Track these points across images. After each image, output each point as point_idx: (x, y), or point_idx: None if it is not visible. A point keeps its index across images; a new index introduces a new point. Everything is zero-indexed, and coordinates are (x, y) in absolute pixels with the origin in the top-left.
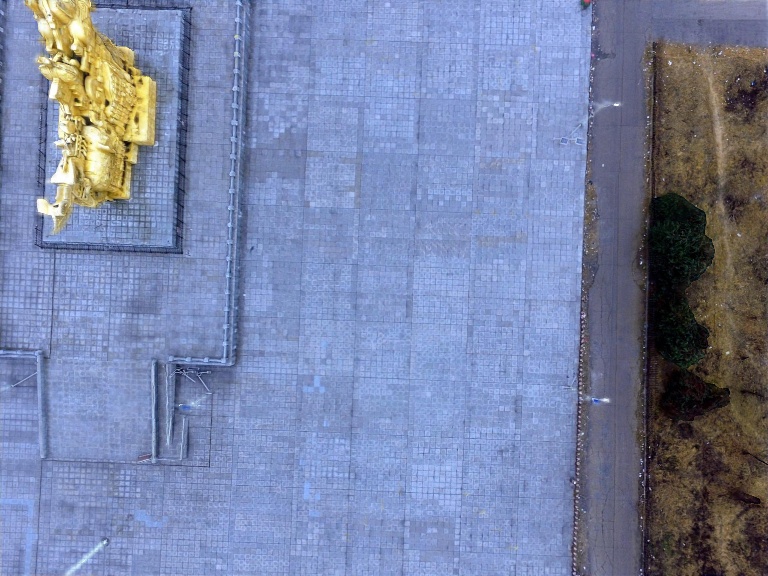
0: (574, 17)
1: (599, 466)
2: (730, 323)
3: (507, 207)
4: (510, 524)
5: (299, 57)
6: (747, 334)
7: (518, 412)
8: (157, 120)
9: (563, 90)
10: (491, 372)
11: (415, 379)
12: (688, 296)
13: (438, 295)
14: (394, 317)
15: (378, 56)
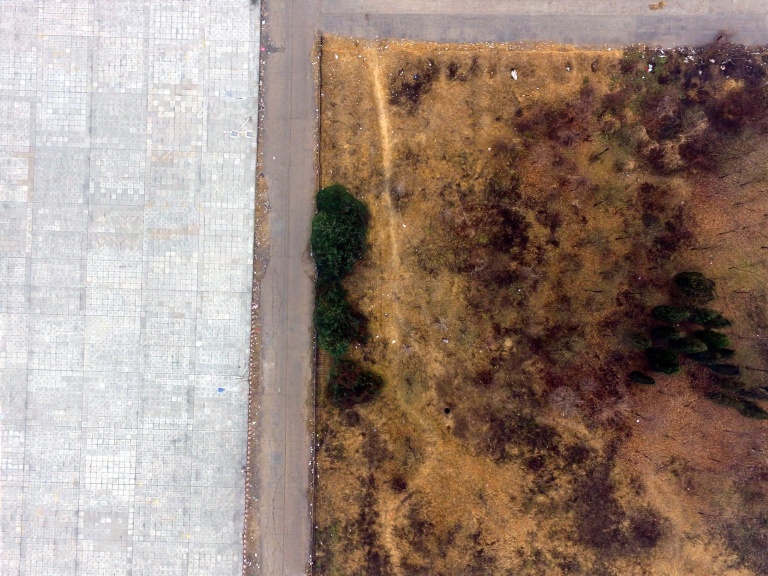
0: (243, 11)
1: (270, 454)
2: (396, 312)
3: (179, 200)
4: (182, 513)
5: None
6: (412, 323)
7: (190, 402)
8: None
9: (233, 84)
10: (164, 363)
11: (89, 371)
12: (356, 286)
13: (111, 287)
14: (68, 310)
15: (49, 50)
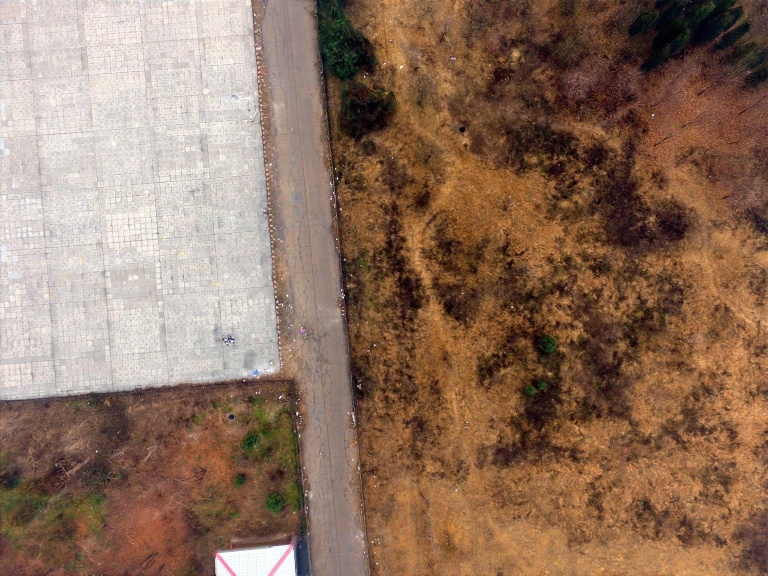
0: None
1: (290, 194)
2: (400, 37)
3: None
4: (209, 262)
5: None
6: (418, 46)
7: (204, 151)
8: None
9: None
10: (173, 115)
11: (99, 130)
12: (357, 16)
13: (112, 44)
14: (70, 71)
15: None
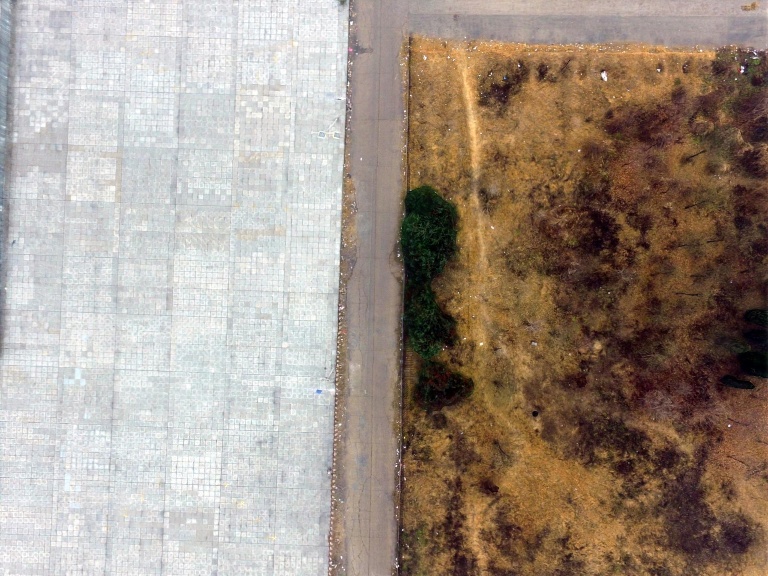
0: (331, 12)
1: (356, 456)
2: (484, 314)
3: (266, 200)
4: (268, 514)
5: (60, 52)
6: (500, 325)
7: (276, 403)
8: None
9: (321, 84)
10: (250, 364)
11: (175, 371)
12: (443, 288)
13: (198, 288)
14: (154, 310)
15: (138, 51)
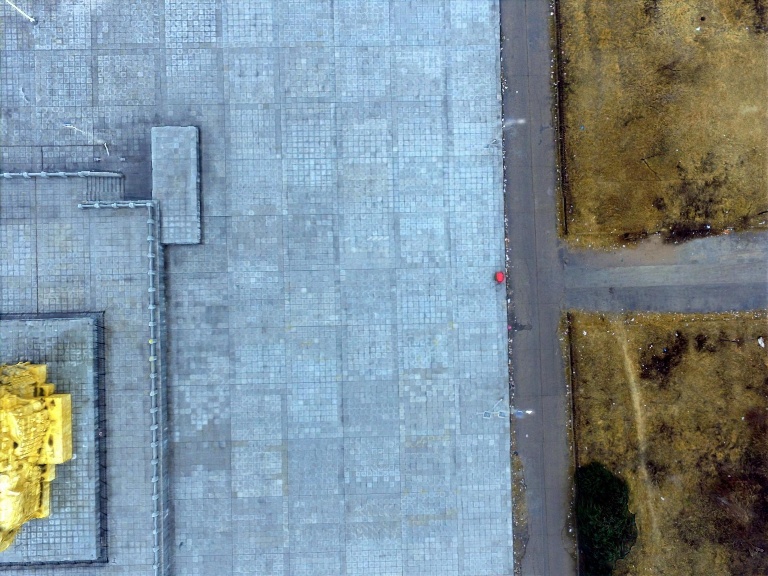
0: (489, 292)
1: None
2: None
3: (435, 484)
4: None
5: (218, 347)
6: None
7: None
8: (74, 432)
9: (483, 365)
10: None
11: None
12: (618, 562)
13: None
14: None
15: (297, 342)
